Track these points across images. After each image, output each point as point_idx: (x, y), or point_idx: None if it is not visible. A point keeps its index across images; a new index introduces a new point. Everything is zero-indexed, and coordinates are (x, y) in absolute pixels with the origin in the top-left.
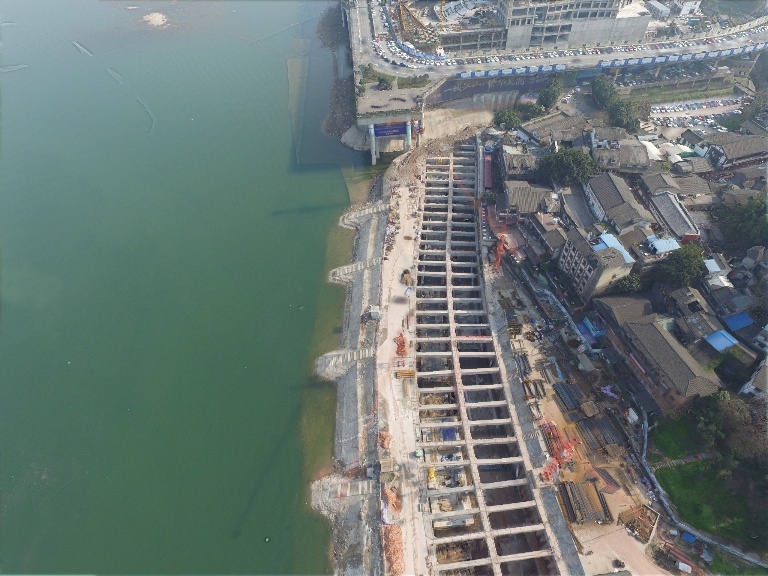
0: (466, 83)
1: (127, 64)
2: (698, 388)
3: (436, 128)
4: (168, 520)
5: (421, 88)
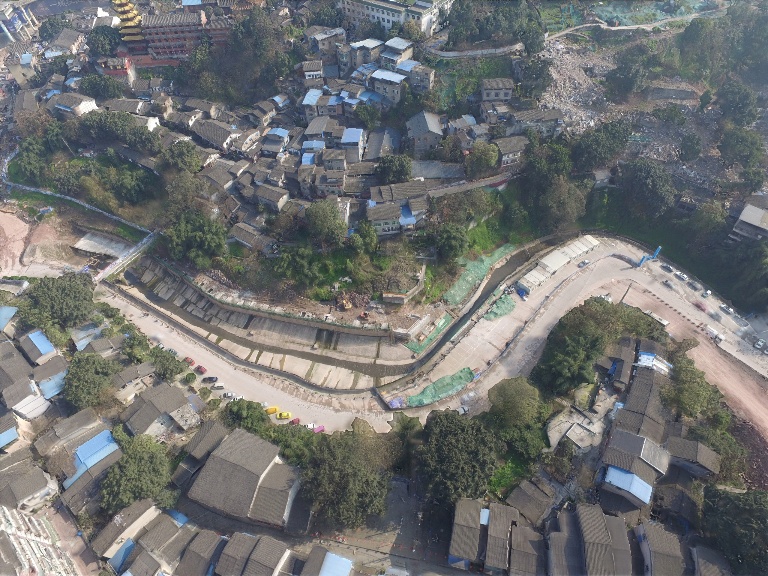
0: None
1: None
2: None
3: None
4: None
5: (19, 1)
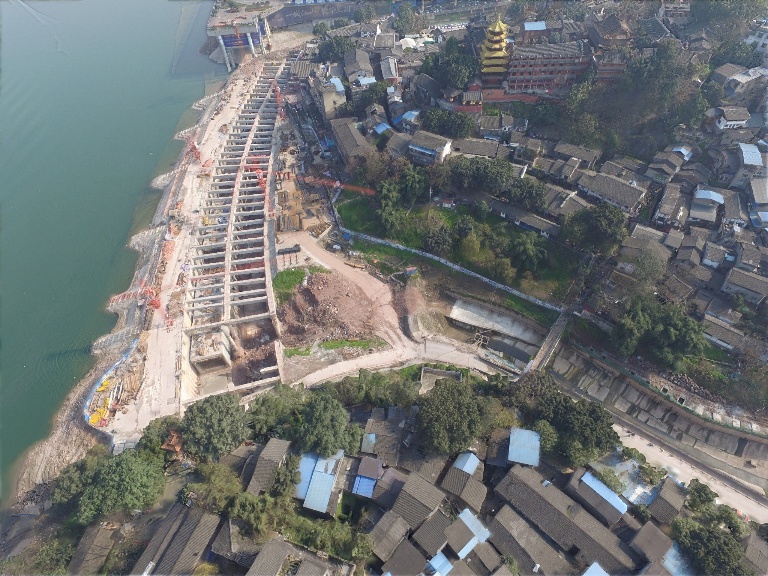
0: (303, 10)
1: (50, 13)
2: (359, 152)
3: (282, 46)
4: (34, 256)
5: (262, 11)
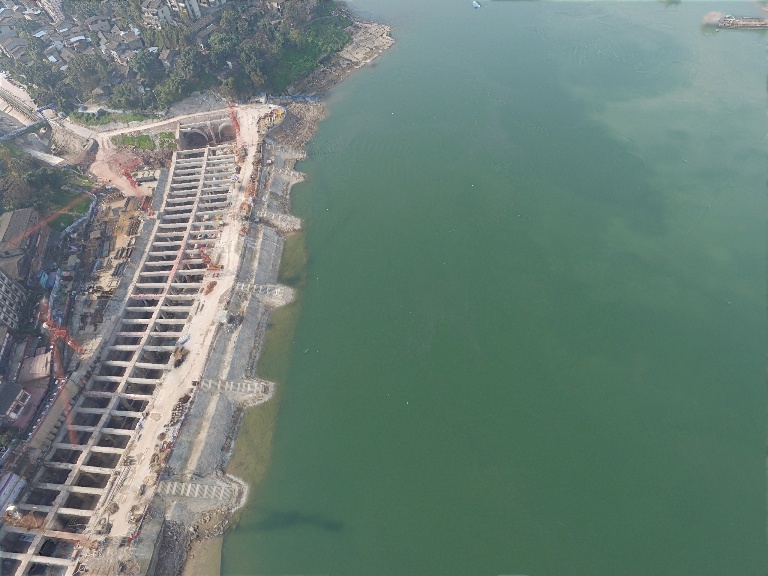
0: None
1: None
2: None
3: None
4: (387, 210)
5: None
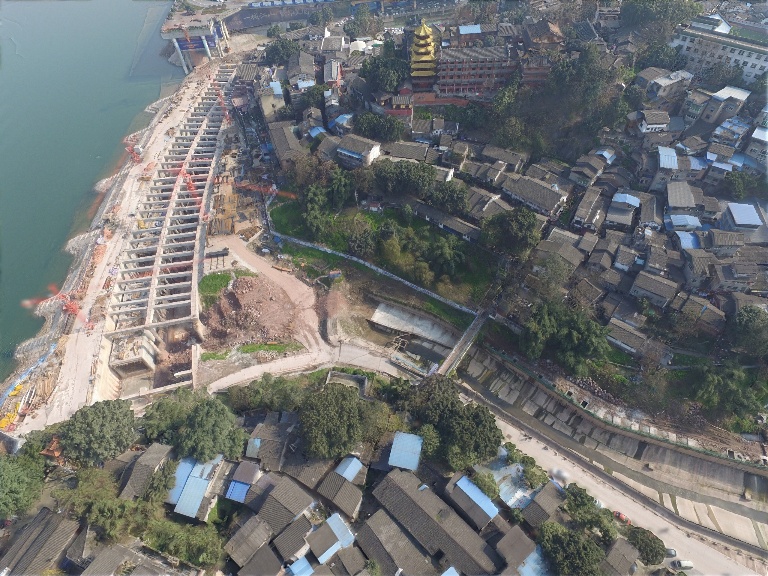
0: (262, 13)
1: (17, 16)
2: (291, 155)
3: (241, 48)
4: None
5: (218, 14)
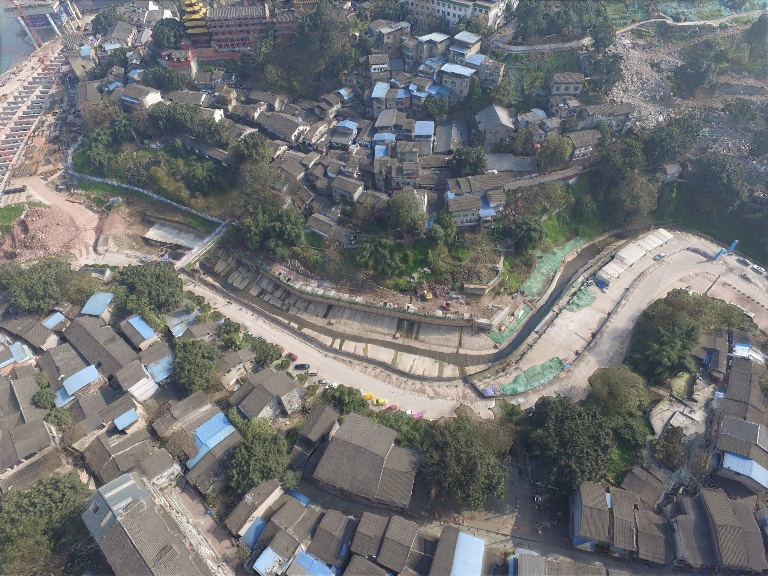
0: None
1: None
2: None
3: None
4: None
5: None
